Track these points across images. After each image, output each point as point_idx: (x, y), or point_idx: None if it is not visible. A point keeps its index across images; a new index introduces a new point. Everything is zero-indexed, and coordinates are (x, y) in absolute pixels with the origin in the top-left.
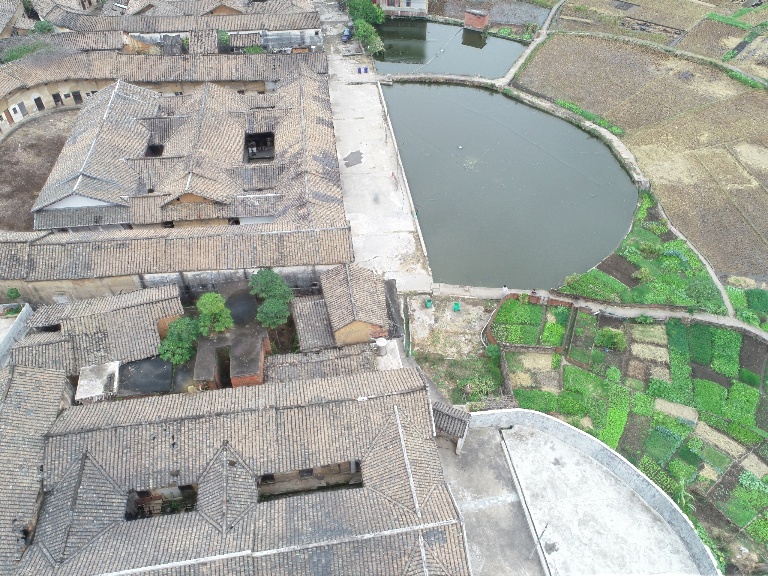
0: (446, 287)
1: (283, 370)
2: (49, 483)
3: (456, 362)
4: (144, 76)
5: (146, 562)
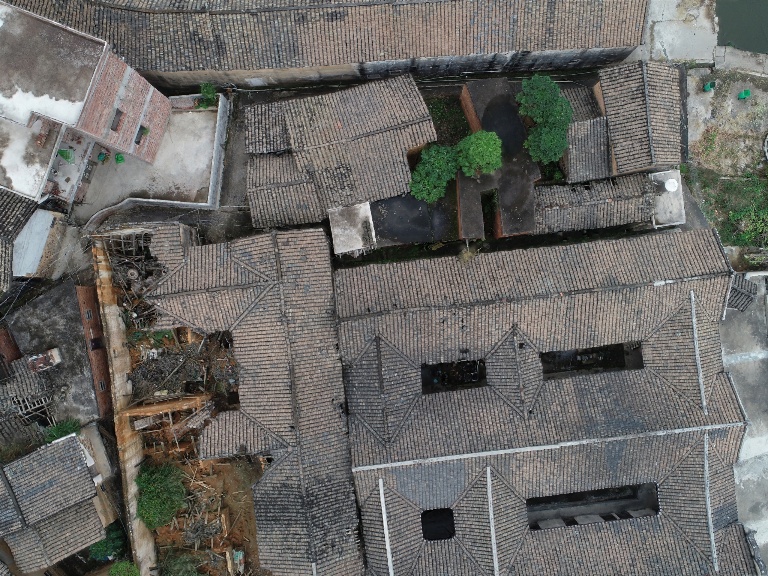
0: (734, 55)
1: (552, 214)
2: (347, 359)
3: (733, 186)
4: None
5: (466, 448)
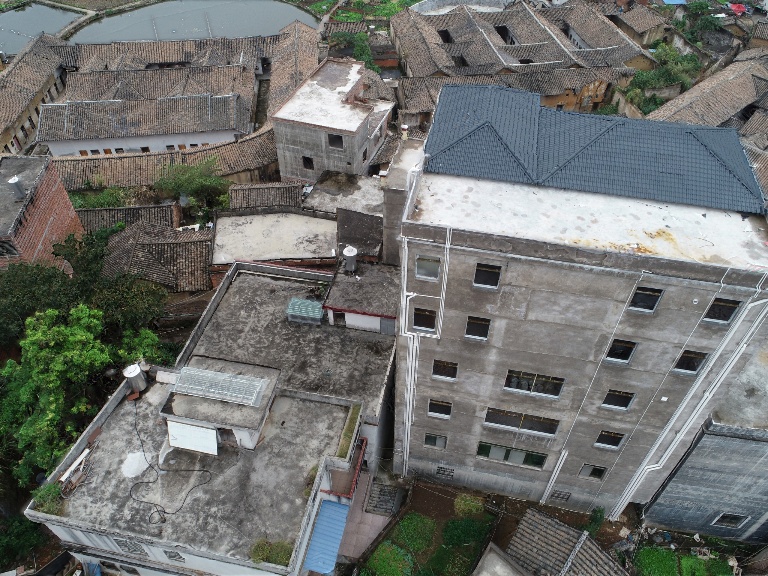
0: None
1: None
2: None
3: None
4: (13, 112)
5: None
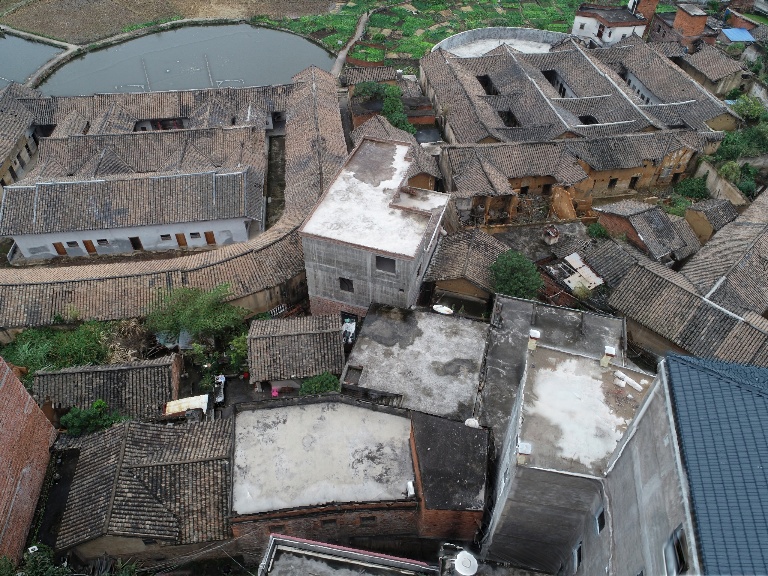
0: None
1: None
2: None
3: None
4: None
5: None
